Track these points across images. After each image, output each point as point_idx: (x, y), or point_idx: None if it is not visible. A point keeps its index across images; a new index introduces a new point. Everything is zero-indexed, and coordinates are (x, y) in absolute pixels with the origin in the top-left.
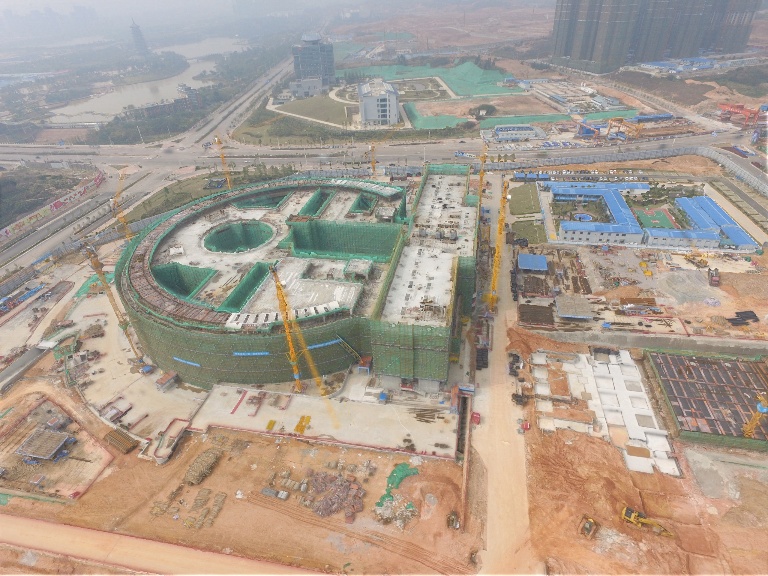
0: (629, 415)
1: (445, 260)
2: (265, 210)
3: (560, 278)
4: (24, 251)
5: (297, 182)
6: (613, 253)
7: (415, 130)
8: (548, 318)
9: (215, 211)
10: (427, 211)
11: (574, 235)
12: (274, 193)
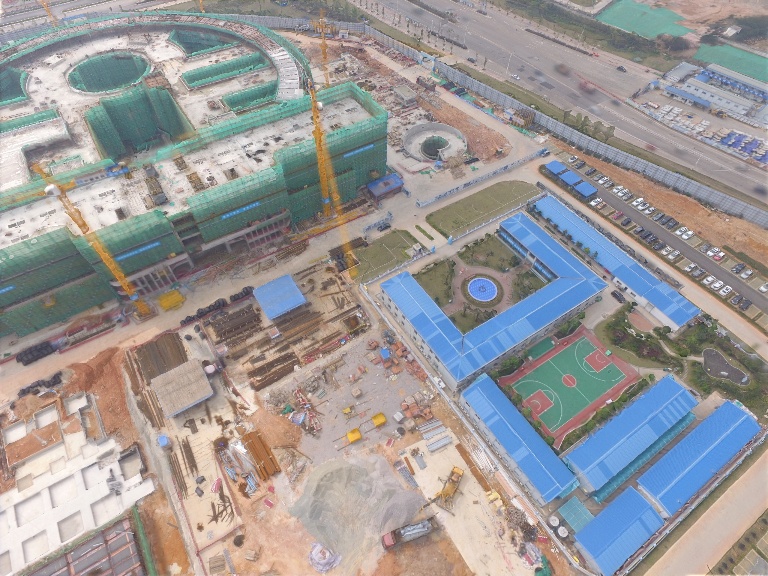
0: (2, 544)
1: (95, 221)
2: (181, 53)
3: (275, 342)
4: (93, 4)
5: (251, 33)
6: (389, 369)
7: (590, 19)
8: (154, 373)
9: (154, 32)
10: (229, 147)
11: (391, 303)
12: (224, 36)
